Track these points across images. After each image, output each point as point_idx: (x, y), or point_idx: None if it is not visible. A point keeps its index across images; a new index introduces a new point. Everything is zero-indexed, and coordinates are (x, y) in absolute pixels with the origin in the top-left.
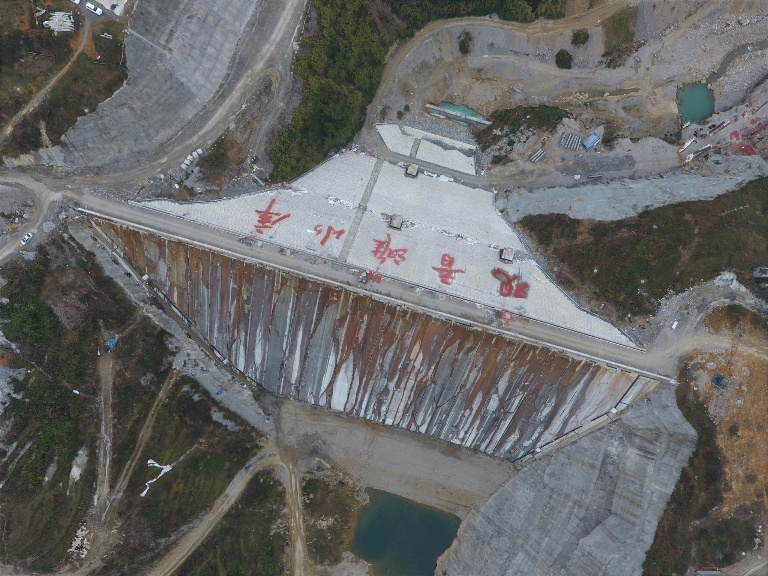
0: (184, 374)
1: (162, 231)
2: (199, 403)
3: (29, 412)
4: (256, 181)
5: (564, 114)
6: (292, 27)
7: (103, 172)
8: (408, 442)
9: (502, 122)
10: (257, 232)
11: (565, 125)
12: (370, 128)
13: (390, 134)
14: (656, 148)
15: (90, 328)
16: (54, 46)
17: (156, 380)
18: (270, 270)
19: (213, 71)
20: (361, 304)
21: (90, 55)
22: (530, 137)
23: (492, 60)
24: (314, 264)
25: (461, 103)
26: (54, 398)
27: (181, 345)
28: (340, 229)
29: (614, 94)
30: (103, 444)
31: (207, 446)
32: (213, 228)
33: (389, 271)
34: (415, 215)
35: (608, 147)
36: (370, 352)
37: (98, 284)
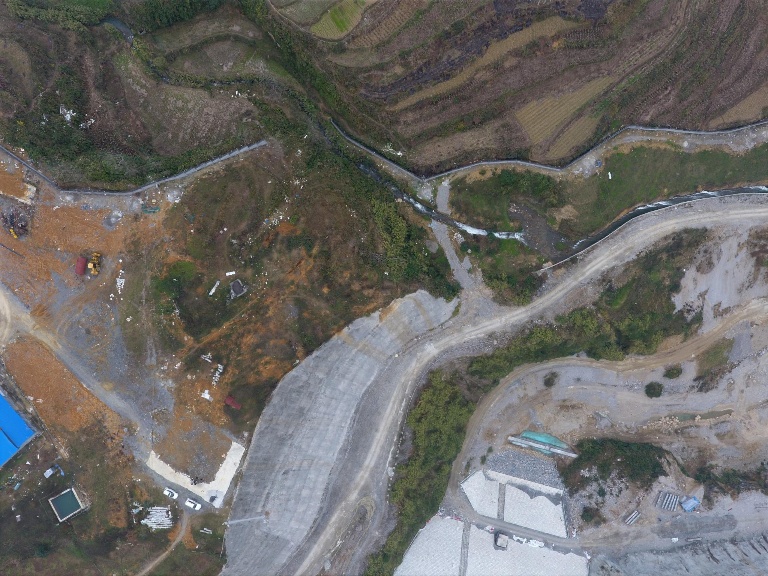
0: None
1: None
2: None
3: None
4: None
5: (659, 469)
6: (386, 450)
7: None
8: None
9: (590, 462)
10: None
11: (661, 483)
12: (455, 487)
13: (475, 488)
14: (759, 506)
15: None
16: (151, 539)
17: None
18: None
19: (307, 511)
20: None
21: (189, 547)
22: (623, 491)
23: (578, 391)
24: None
25: (544, 432)
26: None
27: None
28: None
29: (706, 417)
30: None
31: None
32: None
33: None
34: None
35: (706, 501)
36: None
37: None
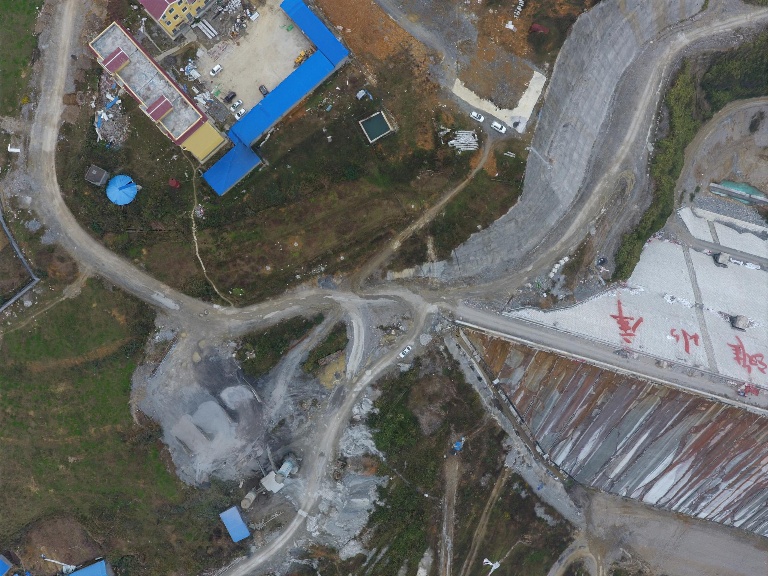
0: (514, 472)
1: (538, 343)
2: (527, 500)
3: (391, 519)
4: (600, 282)
5: None
6: (645, 127)
7: (475, 282)
8: (721, 536)
9: None
10: (626, 341)
11: None
12: (672, 214)
13: (688, 218)
14: None
15: (444, 433)
16: None
17: (494, 480)
18: (642, 381)
19: (575, 176)
20: (731, 414)
21: (490, 173)
22: None
23: None
24: (691, 376)
25: (743, 181)
26: (414, 504)
27: (512, 443)
28: (693, 333)
29: None
30: (444, 544)
31: (531, 542)
32: (588, 340)
33: (761, 382)
34: (750, 313)
35: None
36: (716, 455)
37: (459, 391)
